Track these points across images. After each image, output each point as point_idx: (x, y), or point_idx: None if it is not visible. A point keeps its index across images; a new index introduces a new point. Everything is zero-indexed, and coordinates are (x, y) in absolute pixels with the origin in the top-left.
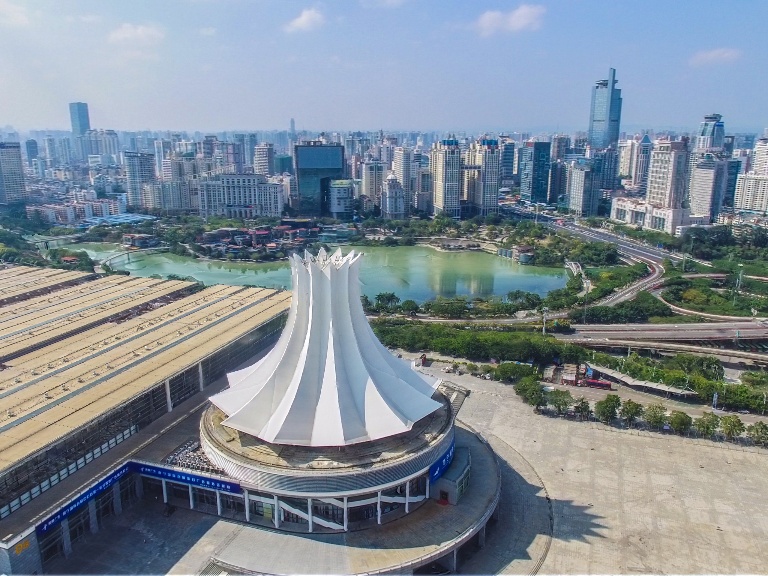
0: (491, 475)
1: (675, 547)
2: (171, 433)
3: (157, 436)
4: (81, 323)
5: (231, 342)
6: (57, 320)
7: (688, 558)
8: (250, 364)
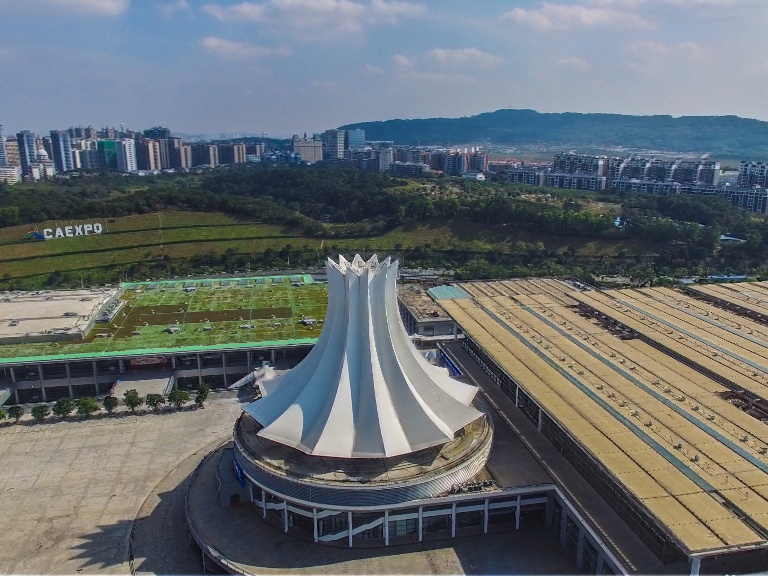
0: (197, 505)
1: (7, 549)
2: (477, 394)
3: (482, 390)
4: (731, 374)
5: (530, 395)
6: (764, 372)
7: (2, 541)
8: (574, 480)
